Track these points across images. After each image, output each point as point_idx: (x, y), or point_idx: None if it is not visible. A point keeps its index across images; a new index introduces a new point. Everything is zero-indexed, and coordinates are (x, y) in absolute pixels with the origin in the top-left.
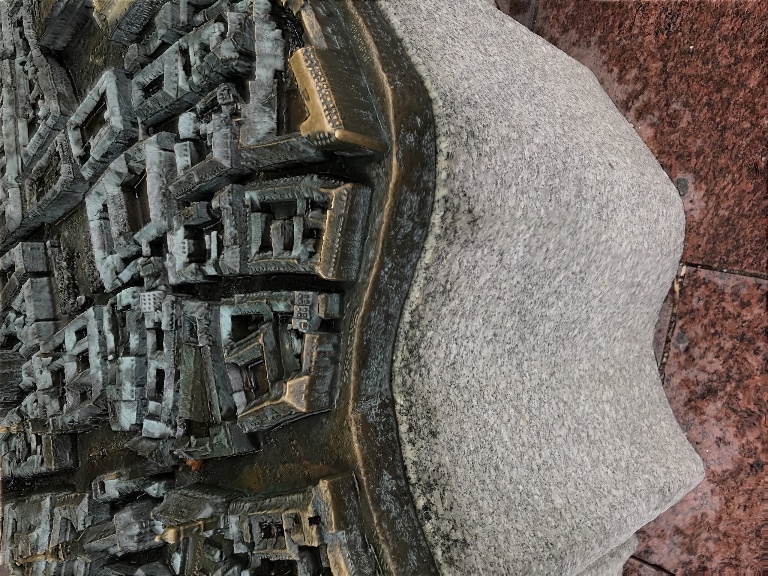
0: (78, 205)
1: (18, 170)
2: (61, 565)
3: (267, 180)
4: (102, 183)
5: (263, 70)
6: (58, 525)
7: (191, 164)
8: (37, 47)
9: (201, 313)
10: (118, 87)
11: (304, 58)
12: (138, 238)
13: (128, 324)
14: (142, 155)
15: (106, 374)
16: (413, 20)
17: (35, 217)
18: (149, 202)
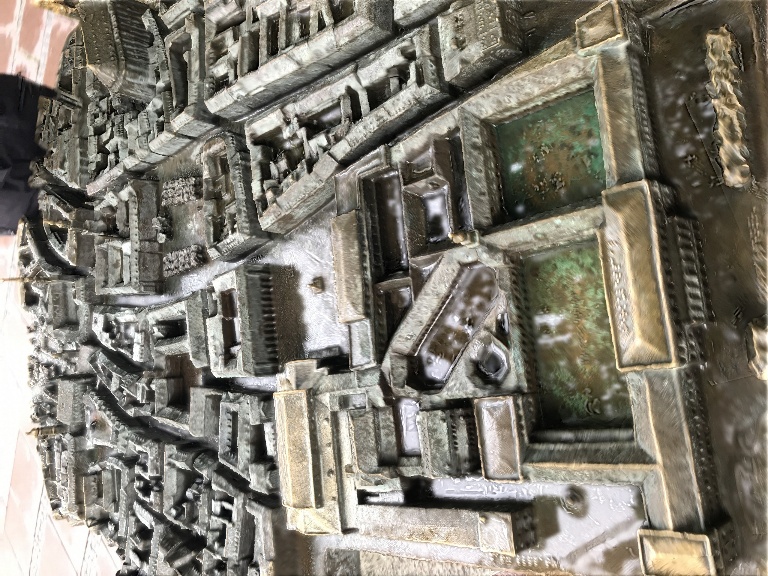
0: None
1: (251, 91)
2: None
3: None
4: None
5: None
6: None
7: None
8: (352, 145)
9: None
10: None
11: None
12: None
13: None
14: None
15: None
16: None
17: None
18: (161, 418)
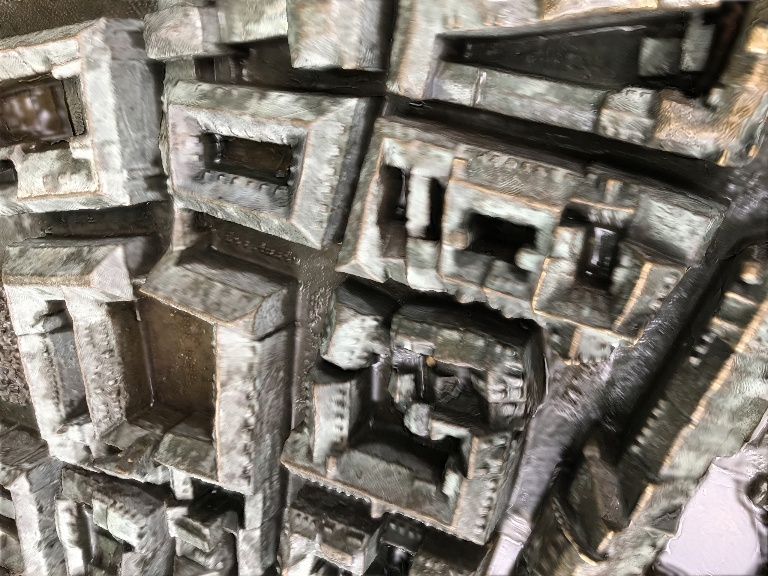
0: None
1: None
2: None
3: None
4: (58, 287)
5: (688, 456)
6: None
7: (348, 435)
8: None
9: None
10: (115, 82)
11: None
12: None
13: (124, 570)
14: (193, 314)
15: (53, 566)
16: None
17: None
18: (218, 451)
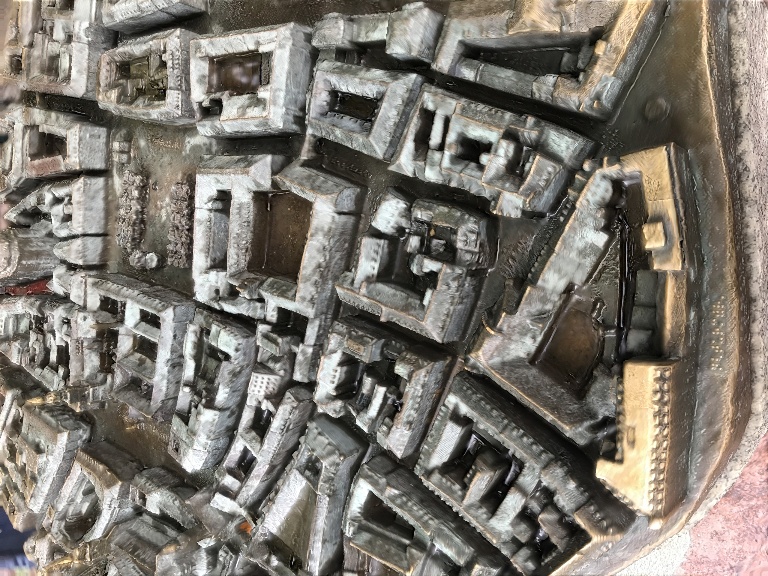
0: (170, 125)
1: (90, 16)
2: (71, 503)
3: (488, 398)
4: (228, 176)
5: (554, 275)
6: (76, 476)
7: (377, 274)
8: None
9: (331, 461)
10: (291, 57)
11: (654, 386)
12: (265, 295)
13: (221, 374)
14: (303, 195)
15: (171, 383)
16: (767, 241)
17: (106, 109)
18: (300, 279)
